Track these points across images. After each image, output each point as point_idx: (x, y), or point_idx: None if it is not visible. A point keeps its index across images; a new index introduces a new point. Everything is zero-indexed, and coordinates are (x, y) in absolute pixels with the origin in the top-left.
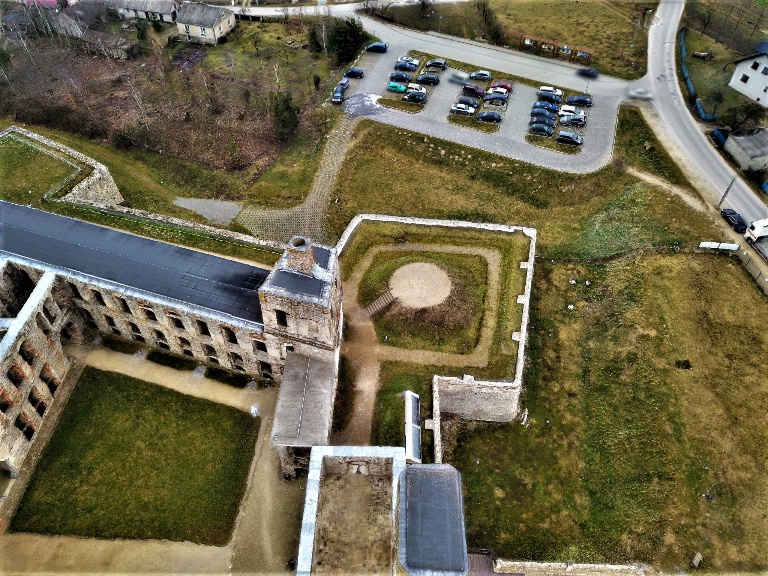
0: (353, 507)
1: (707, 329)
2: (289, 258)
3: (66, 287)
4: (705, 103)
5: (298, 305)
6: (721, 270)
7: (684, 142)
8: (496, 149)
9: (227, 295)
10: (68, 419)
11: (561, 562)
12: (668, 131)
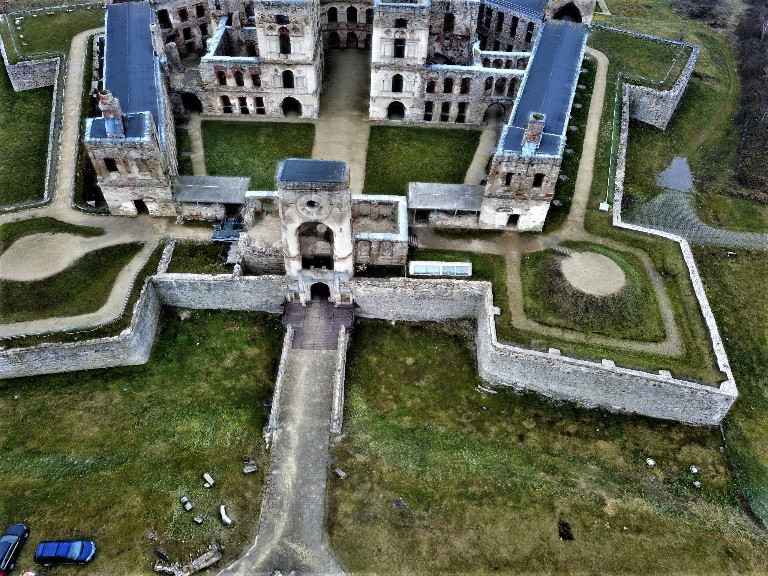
0: None
1: None
2: None
3: None
4: None
5: None
6: None
7: None
8: None
9: None
10: (441, 131)
11: (354, 396)
12: None
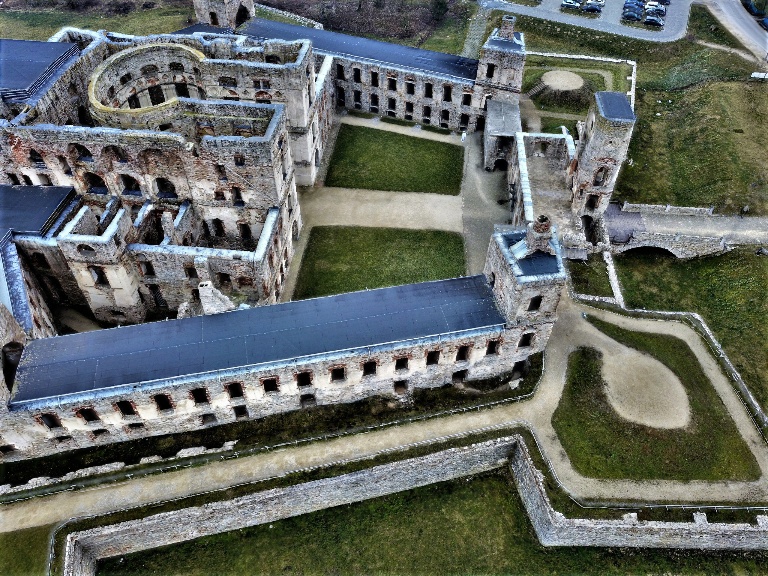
0: (539, 168)
1: (755, 116)
2: (501, 29)
3: (335, 69)
4: (758, 4)
5: (506, 57)
6: (766, 90)
7: (741, 25)
8: (599, 28)
9: (448, 67)
10: (341, 144)
11: None
12: (729, 19)
